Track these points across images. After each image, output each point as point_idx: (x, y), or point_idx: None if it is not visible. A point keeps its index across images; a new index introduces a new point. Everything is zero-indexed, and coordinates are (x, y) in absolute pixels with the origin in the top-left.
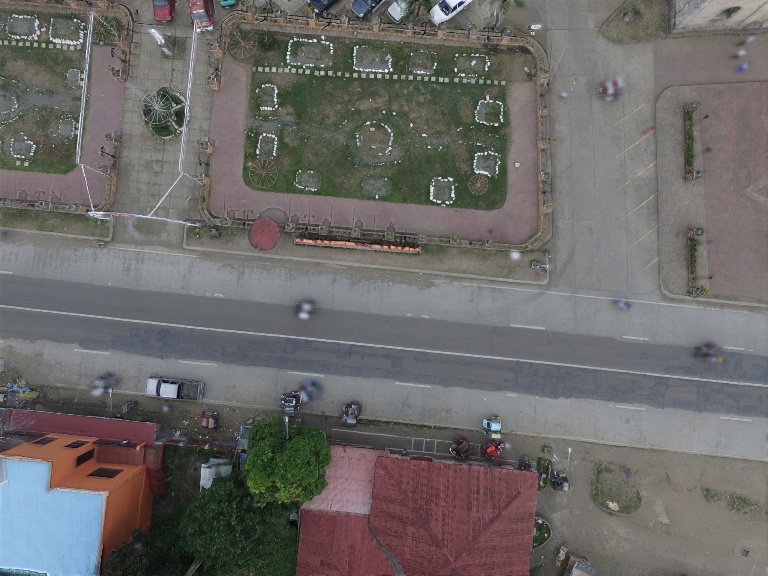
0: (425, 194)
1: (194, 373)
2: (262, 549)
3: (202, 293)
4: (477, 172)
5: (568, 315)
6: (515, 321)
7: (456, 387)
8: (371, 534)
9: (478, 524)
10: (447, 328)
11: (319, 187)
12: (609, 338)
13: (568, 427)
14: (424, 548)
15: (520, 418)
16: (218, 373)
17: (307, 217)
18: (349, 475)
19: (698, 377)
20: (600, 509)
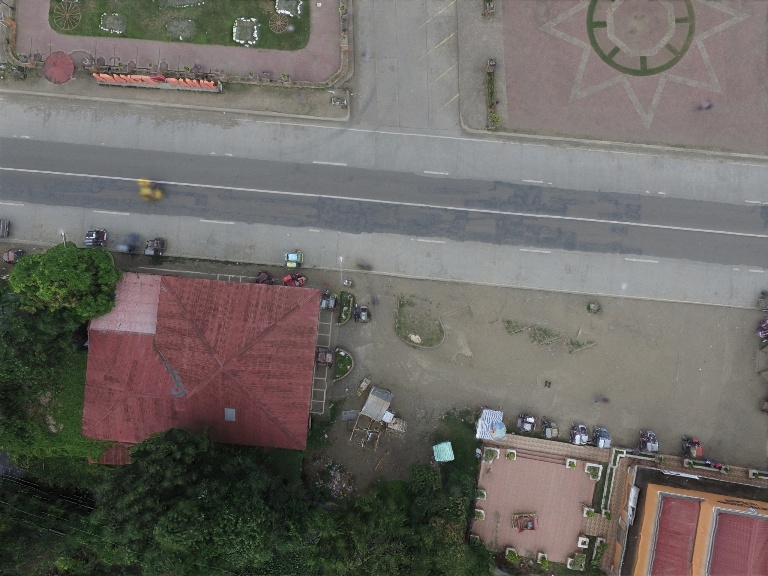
0: (229, 35)
1: (1, 213)
2: (55, 372)
3: (9, 135)
4: (279, 12)
5: (369, 151)
6: (317, 158)
7: (259, 223)
8: (155, 350)
9: (252, 333)
10: (250, 166)
11: (124, 30)
12: (410, 173)
13: (370, 261)
14: (198, 356)
15: (322, 253)
16: (25, 213)
17: (113, 59)
18: (140, 299)
19: (498, 210)
20: (404, 342)
